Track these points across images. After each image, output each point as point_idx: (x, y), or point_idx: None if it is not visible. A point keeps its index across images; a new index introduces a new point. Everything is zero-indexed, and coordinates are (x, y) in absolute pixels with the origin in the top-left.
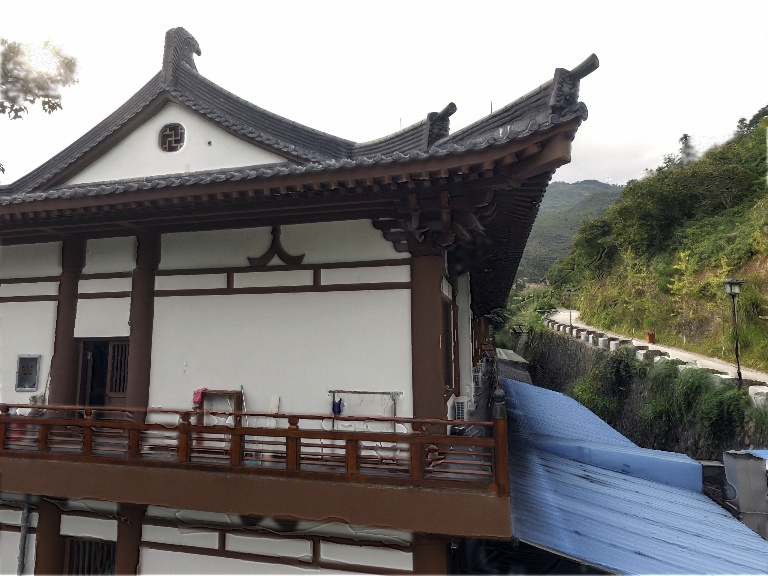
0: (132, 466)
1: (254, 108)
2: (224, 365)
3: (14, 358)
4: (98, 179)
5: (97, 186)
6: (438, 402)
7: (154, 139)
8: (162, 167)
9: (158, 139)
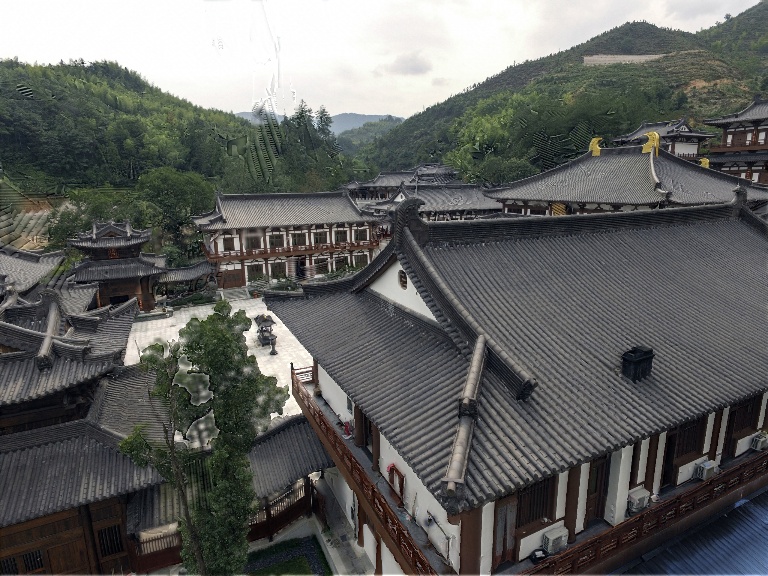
0: (361, 492)
1: (433, 281)
2: (400, 457)
3: (346, 395)
4: (379, 290)
5: (377, 297)
6: (469, 557)
7: (396, 277)
8: (400, 298)
9: (398, 278)
